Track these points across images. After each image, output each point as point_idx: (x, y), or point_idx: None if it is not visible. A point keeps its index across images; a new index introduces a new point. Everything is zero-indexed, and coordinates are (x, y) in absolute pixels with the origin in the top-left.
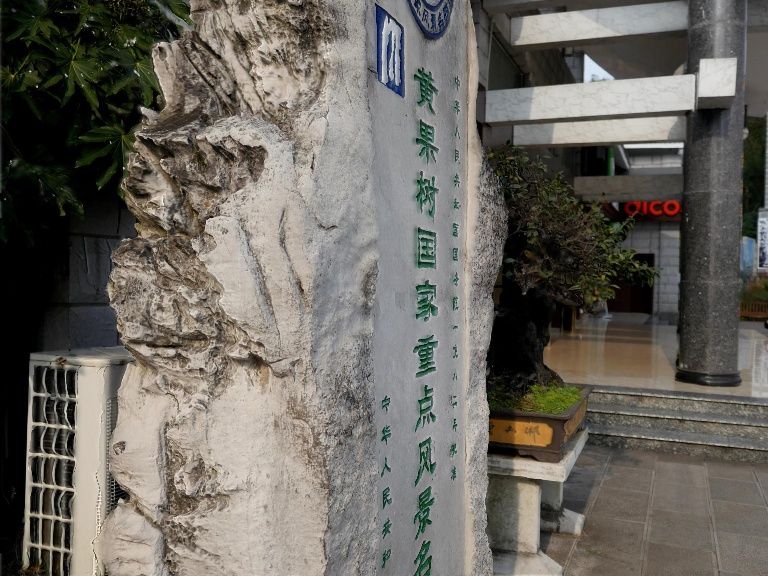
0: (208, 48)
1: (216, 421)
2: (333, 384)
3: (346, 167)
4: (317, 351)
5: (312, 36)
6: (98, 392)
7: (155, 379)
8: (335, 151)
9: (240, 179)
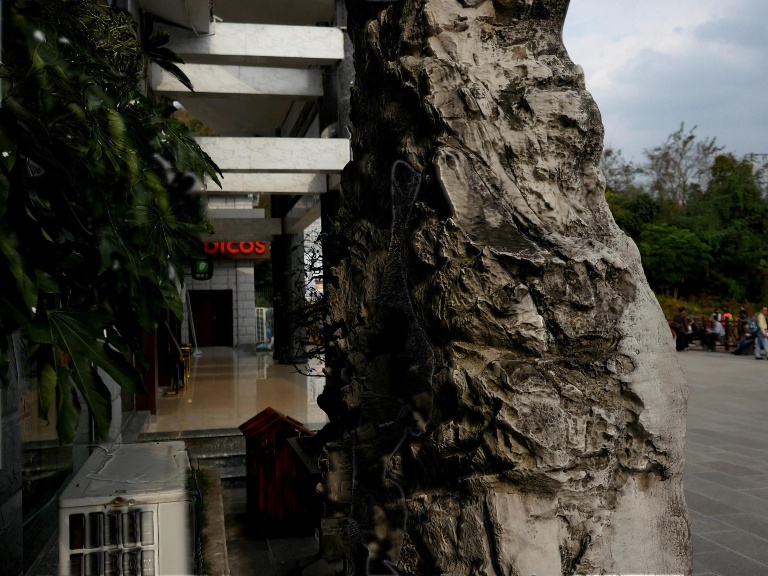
0: (480, 159)
1: (613, 533)
2: None
3: None
4: None
5: (582, 158)
6: (190, 531)
7: (555, 504)
8: None
9: (612, 299)
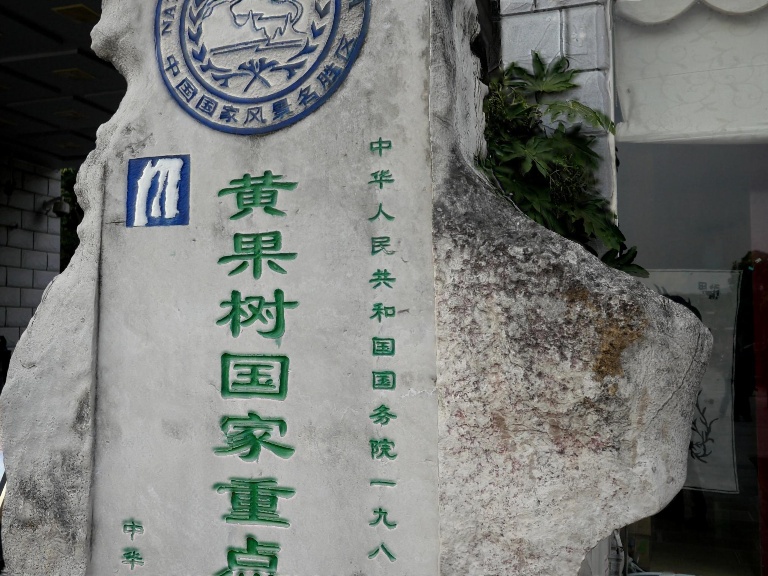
0: None
1: None
2: (18, 486)
3: (58, 317)
4: (10, 458)
5: None
6: None
7: None
8: (51, 306)
9: None
